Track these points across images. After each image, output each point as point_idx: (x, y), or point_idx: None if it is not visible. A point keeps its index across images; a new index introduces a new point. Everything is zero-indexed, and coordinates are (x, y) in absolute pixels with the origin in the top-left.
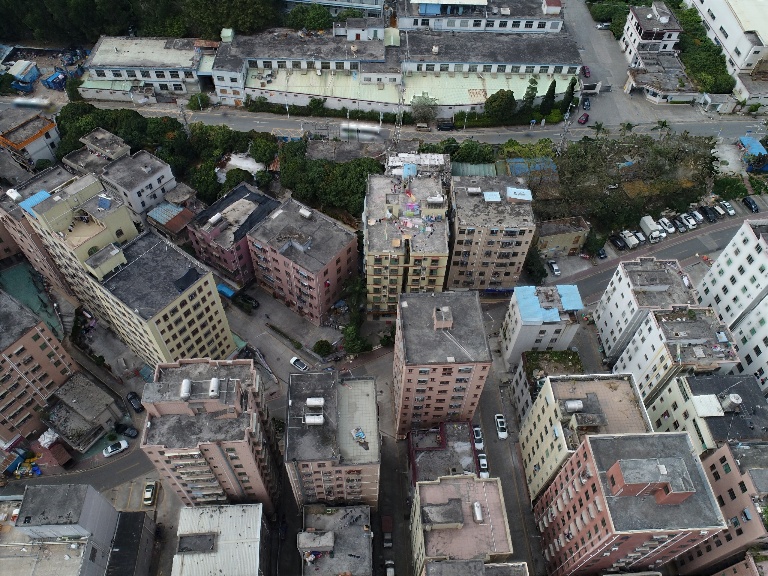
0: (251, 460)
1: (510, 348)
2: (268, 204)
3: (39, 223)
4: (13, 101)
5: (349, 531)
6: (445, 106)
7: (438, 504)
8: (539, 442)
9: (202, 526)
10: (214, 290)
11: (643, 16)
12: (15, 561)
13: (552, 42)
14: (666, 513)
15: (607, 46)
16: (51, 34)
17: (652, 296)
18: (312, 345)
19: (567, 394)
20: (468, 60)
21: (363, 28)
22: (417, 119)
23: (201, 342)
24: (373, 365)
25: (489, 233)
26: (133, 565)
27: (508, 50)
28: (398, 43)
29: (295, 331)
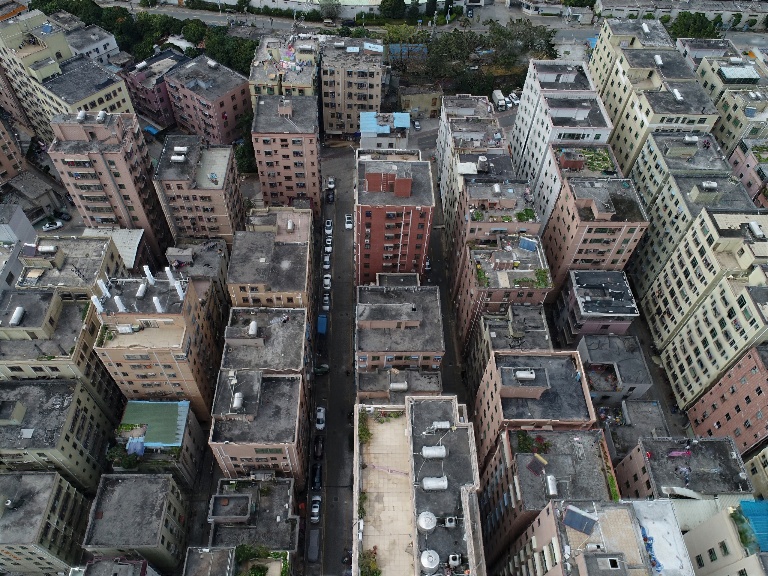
0: (129, 179)
1: None
2: (186, 61)
3: None
4: None
5: (207, 254)
6: (348, 6)
7: (260, 215)
8: None
9: None
10: (127, 99)
11: None
12: None
13: None
14: (398, 200)
15: None
16: None
17: None
18: None
19: None
20: None
21: None
22: (323, 15)
23: None
24: None
25: (346, 74)
26: None
27: None
28: None
29: None
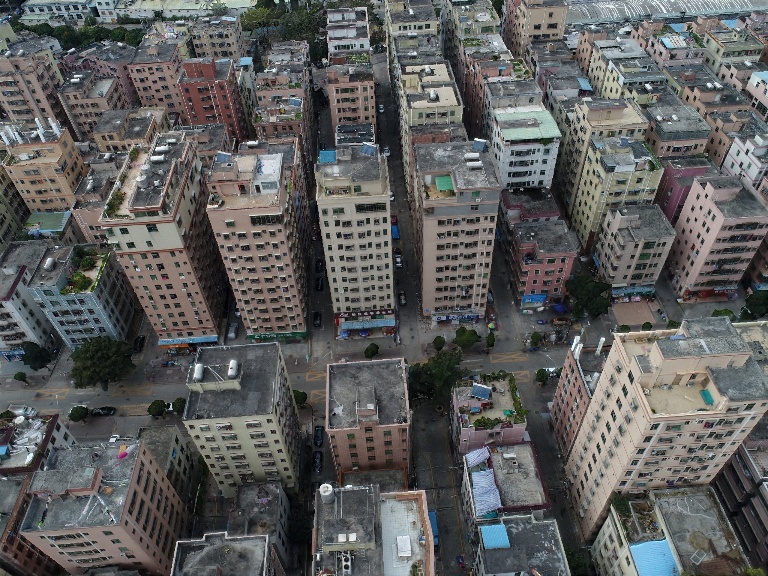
0: (42, 94)
1: None
2: None
3: None
4: None
5: None
6: (233, 9)
7: None
8: None
9: None
10: (54, 63)
11: None
12: None
13: None
14: None
15: None
16: None
17: None
18: None
19: None
20: None
21: None
22: None
23: None
24: None
25: (209, 37)
26: None
27: None
28: None
29: None
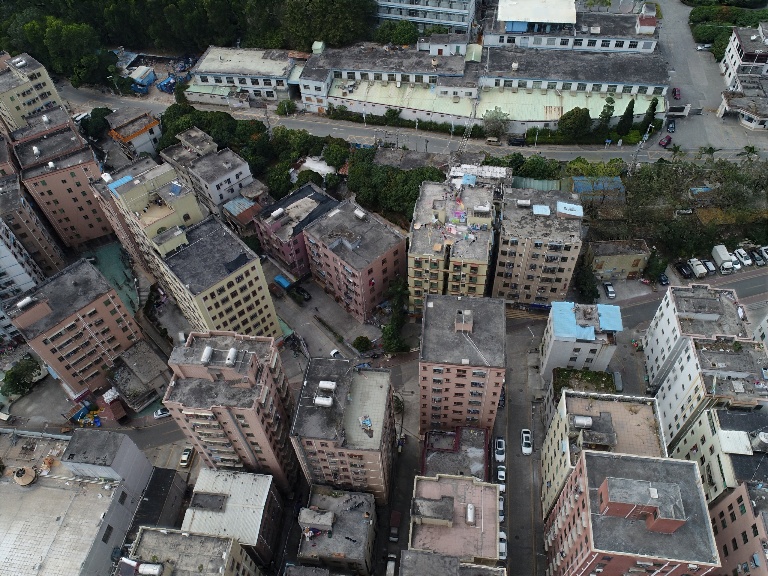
0: (260, 430)
1: (545, 364)
2: (328, 204)
3: (121, 203)
4: (131, 101)
5: (350, 515)
6: (518, 121)
7: (430, 499)
8: (553, 458)
9: (216, 487)
10: (261, 276)
11: (746, 37)
12: (59, 492)
13: (640, 62)
14: (655, 540)
15: (705, 68)
16: (169, 44)
17: (699, 324)
18: (353, 340)
19: (582, 411)
20: (547, 77)
21: (446, 43)
22: (488, 133)
23: (247, 324)
24: (409, 366)
25: (533, 246)
26: (158, 515)
27: (591, 69)
28: (479, 59)
29: (340, 325)
